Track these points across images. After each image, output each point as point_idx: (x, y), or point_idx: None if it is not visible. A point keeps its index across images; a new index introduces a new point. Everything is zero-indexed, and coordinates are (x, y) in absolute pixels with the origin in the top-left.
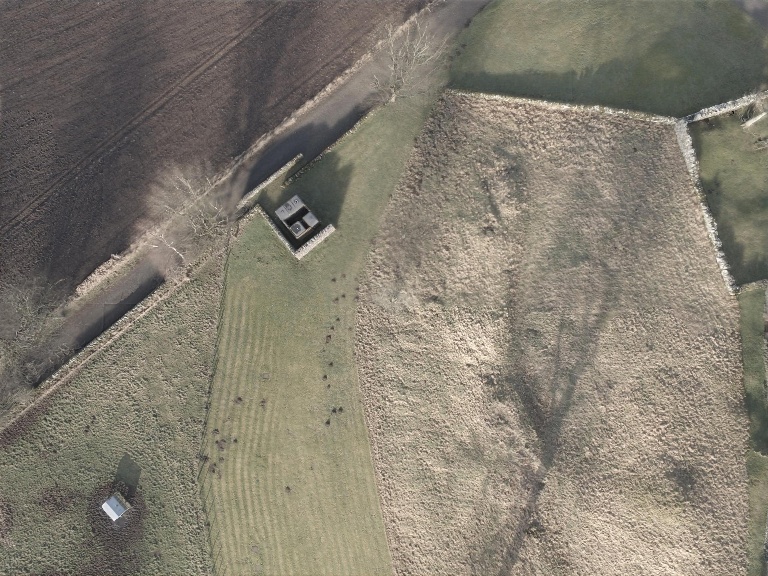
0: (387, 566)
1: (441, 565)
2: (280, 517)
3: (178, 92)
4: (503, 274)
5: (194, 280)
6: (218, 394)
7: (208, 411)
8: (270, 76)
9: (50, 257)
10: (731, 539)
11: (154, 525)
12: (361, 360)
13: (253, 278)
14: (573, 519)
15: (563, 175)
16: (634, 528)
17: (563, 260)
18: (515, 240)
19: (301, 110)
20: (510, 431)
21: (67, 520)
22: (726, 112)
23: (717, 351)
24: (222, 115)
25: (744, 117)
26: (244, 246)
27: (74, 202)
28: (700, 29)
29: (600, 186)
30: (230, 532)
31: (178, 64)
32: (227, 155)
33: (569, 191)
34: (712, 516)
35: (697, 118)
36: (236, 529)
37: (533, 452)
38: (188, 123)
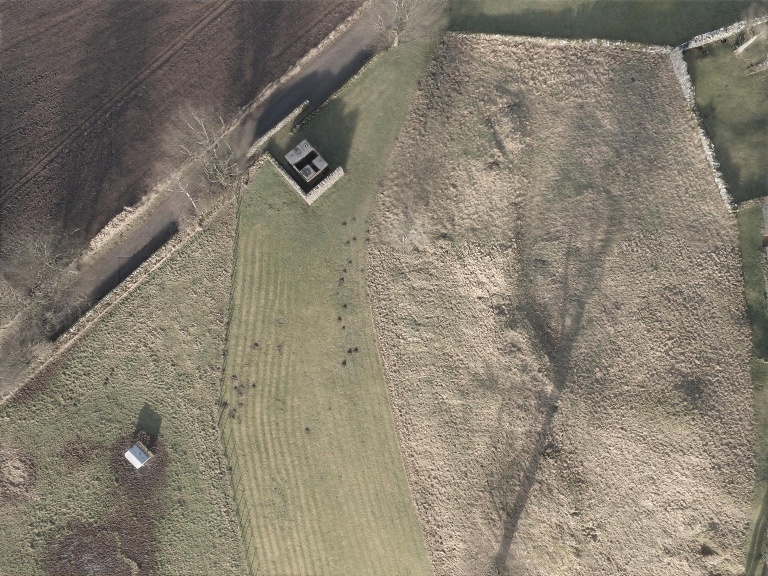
0: (407, 500)
1: (460, 494)
2: (301, 458)
3: (183, 45)
4: (510, 206)
5: (207, 230)
6: (235, 341)
7: (226, 358)
8: (274, 26)
9: (62, 213)
10: (738, 443)
11: (177, 472)
12: (374, 301)
13: (265, 225)
14: (586, 438)
15: (564, 108)
16: (646, 441)
17: (567, 190)
18: (520, 173)
19: (306, 58)
20: (523, 358)
21: (90, 471)
22: (719, 39)
23: (719, 267)
24: (228, 66)
25: (736, 44)
26: (255, 194)
27: (84, 157)
28: None
29: (601, 116)
30: (252, 475)
31: (182, 18)
32: (234, 105)
33: (571, 123)
34: (720, 422)
35: (691, 45)
36: (258, 472)
37: (546, 376)
38: (194, 75)
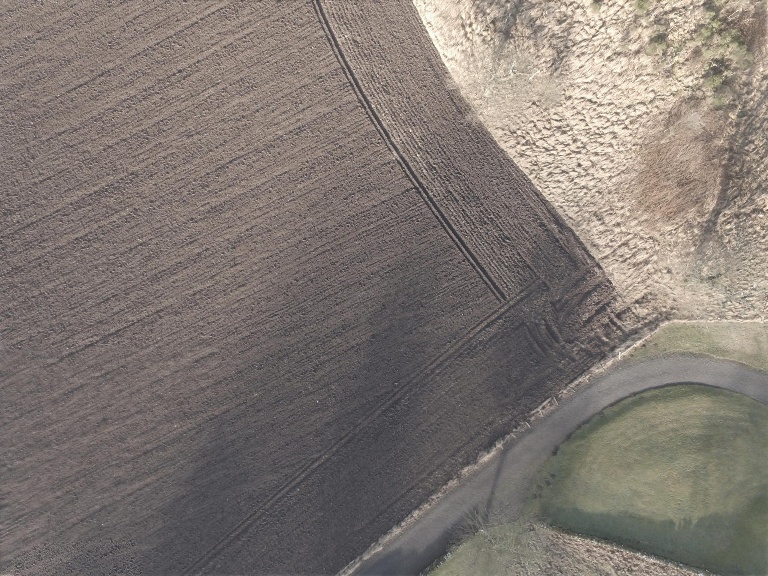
0: None
1: None
2: None
3: (261, 515)
4: None
5: None
6: None
7: None
8: (355, 500)
9: None
10: None
11: None
12: None
13: None
14: None
15: None
16: None
17: None
18: None
19: (389, 537)
20: None
21: None
22: None
23: None
24: (308, 540)
25: None
26: None
27: None
28: None
29: None
30: None
31: (260, 487)
32: None
33: None
34: None
35: None
36: None
37: None
38: (274, 548)
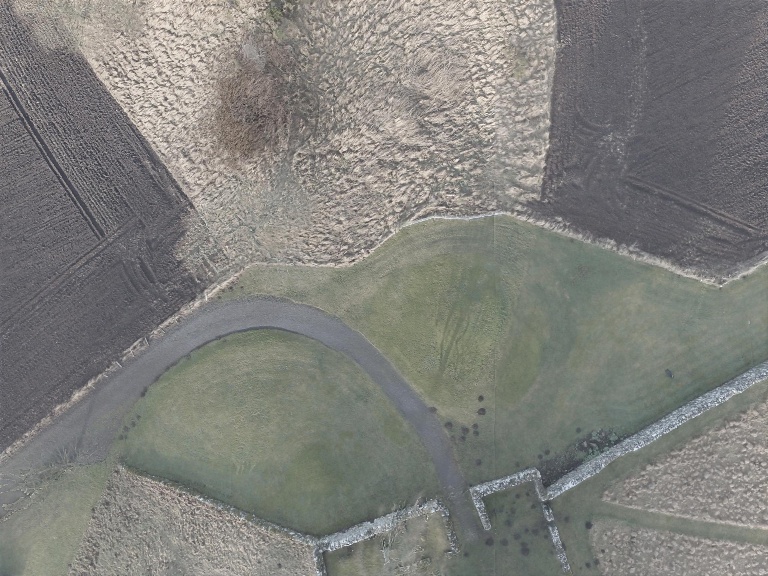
0: None
1: None
2: None
3: None
4: None
5: None
6: None
7: None
8: None
9: None
10: None
11: None
12: None
13: None
14: None
15: None
16: None
17: None
18: None
19: None
20: None
21: None
22: None
23: None
24: None
25: (385, 541)
26: None
27: None
28: (360, 425)
29: None
30: None
31: None
32: None
33: None
34: None
35: (330, 550)
36: None
37: None
38: None
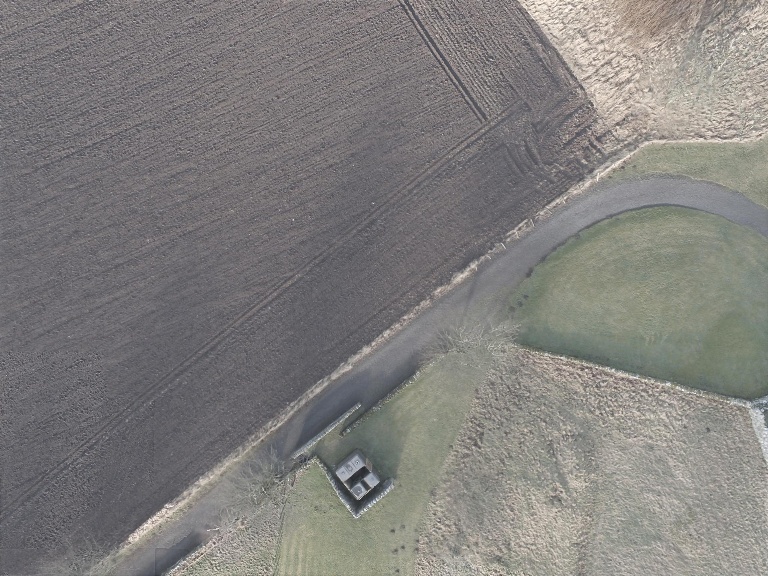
0: None
1: None
2: None
3: (231, 333)
4: (572, 548)
5: (249, 527)
6: None
7: None
8: (326, 319)
9: (100, 502)
10: None
11: None
12: None
13: (310, 526)
14: None
15: (632, 446)
16: None
17: (634, 536)
18: (584, 513)
19: (358, 356)
20: None
21: None
22: None
23: None
24: (277, 358)
25: None
26: (301, 495)
27: (125, 446)
28: None
29: (672, 464)
30: None
31: (231, 304)
32: (282, 400)
33: (639, 464)
34: None
35: None
36: None
37: None
38: (242, 366)
